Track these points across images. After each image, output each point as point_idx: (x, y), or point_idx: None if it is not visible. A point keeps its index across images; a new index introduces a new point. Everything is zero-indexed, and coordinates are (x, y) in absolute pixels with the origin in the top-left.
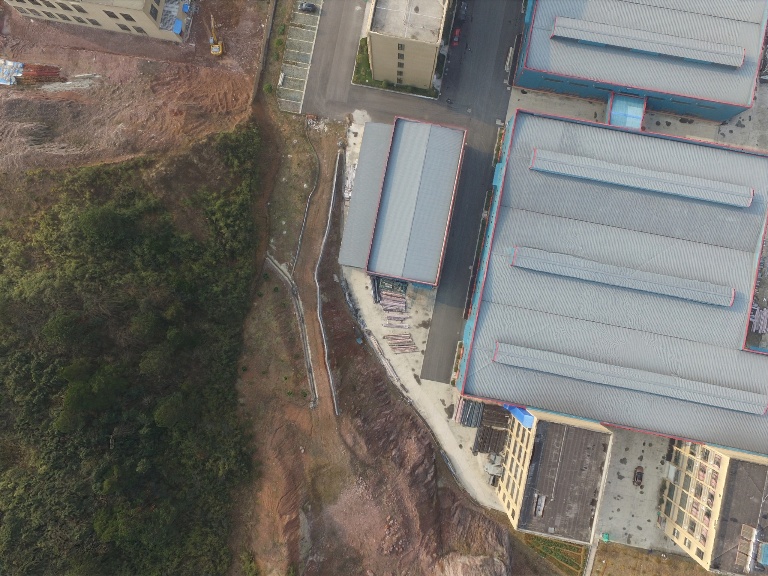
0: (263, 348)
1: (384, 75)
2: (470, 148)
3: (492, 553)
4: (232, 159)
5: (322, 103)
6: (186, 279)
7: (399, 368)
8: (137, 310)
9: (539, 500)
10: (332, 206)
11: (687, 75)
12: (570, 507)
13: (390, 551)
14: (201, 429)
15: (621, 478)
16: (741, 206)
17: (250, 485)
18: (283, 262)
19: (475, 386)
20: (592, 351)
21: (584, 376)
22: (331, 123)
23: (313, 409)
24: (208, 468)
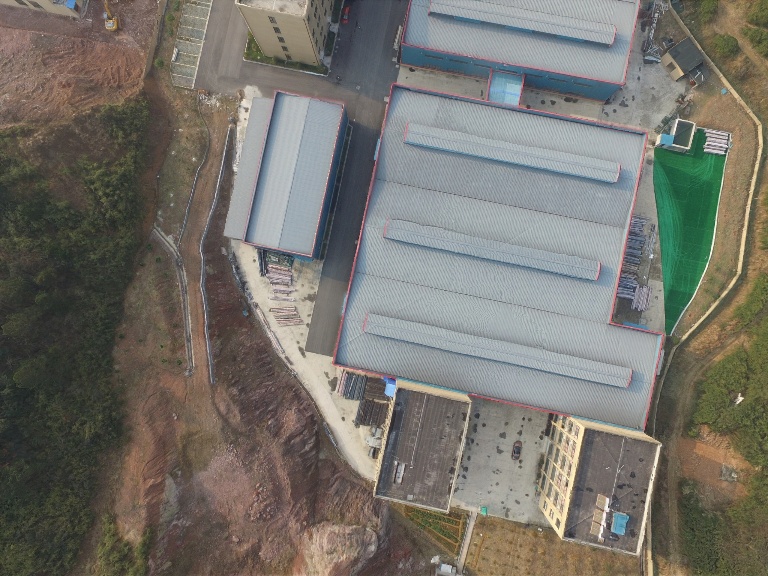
0: (142, 317)
1: (272, 51)
2: (358, 124)
3: (366, 523)
4: (117, 131)
5: (214, 79)
6: (61, 246)
7: (284, 341)
8: (8, 275)
9: (399, 467)
10: (220, 180)
11: (562, 52)
12: (429, 475)
13: (257, 517)
14: (70, 393)
15: (500, 452)
16: (609, 181)
17: (119, 450)
18: (170, 234)
19: (347, 356)
20: (465, 324)
21: (452, 347)
22: (223, 98)
23: (189, 377)
24: (75, 431)
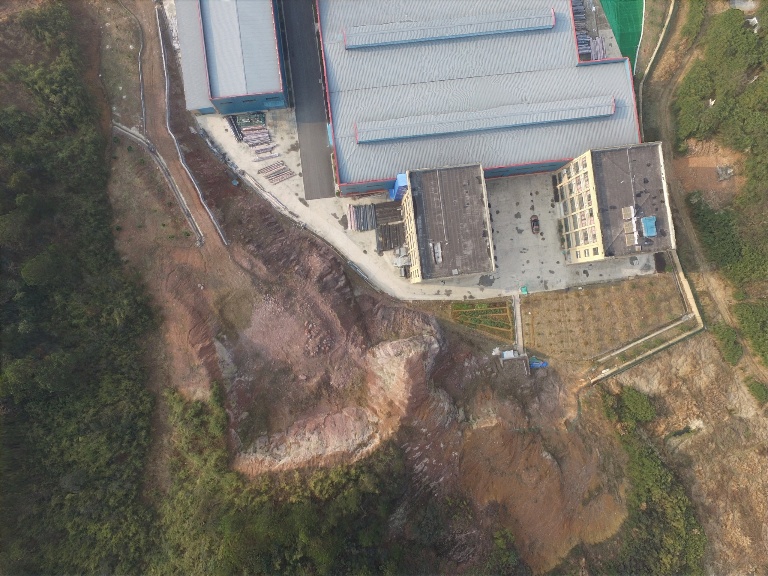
0: (133, 206)
1: None
2: None
3: (421, 332)
4: (41, 32)
5: None
6: (24, 150)
7: (282, 197)
8: None
9: (435, 248)
10: (165, 60)
11: None
12: (465, 245)
13: (316, 352)
14: (85, 289)
15: (521, 232)
16: None
17: (156, 332)
18: (132, 126)
19: (350, 175)
20: None
21: (446, 130)
22: None
23: (201, 247)
24: (104, 323)
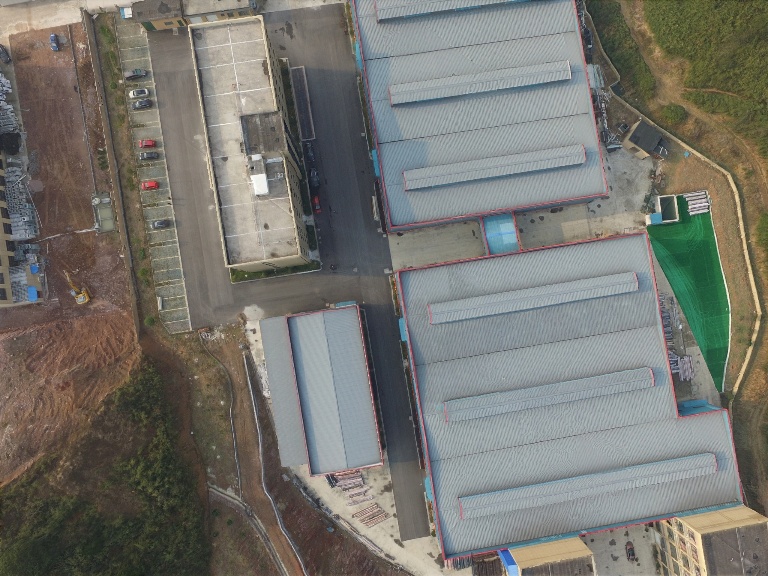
0: None
1: (260, 269)
2: (369, 305)
3: None
4: (138, 414)
5: (209, 312)
6: (133, 564)
7: (378, 540)
8: None
9: None
10: (256, 412)
11: (541, 182)
12: None
13: None
14: None
15: (616, 559)
16: (630, 291)
17: None
18: (227, 487)
19: (454, 545)
20: (548, 466)
21: (549, 499)
22: (226, 329)
23: None
24: None
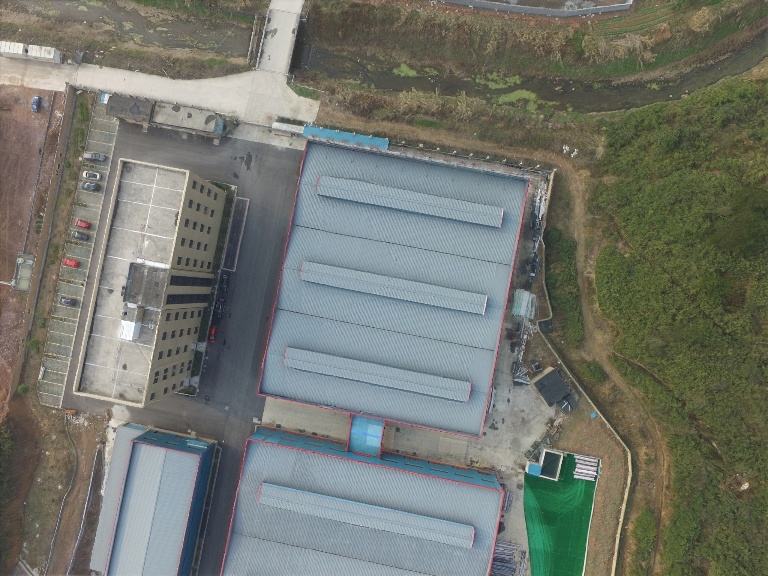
0: None
1: None
2: (227, 446)
3: None
4: None
5: (82, 397)
6: None
7: None
8: None
9: None
10: (88, 506)
11: (420, 403)
12: None
13: None
14: None
15: None
16: None
17: None
18: (35, 566)
19: None
20: None
21: None
22: (91, 418)
23: None
24: None
